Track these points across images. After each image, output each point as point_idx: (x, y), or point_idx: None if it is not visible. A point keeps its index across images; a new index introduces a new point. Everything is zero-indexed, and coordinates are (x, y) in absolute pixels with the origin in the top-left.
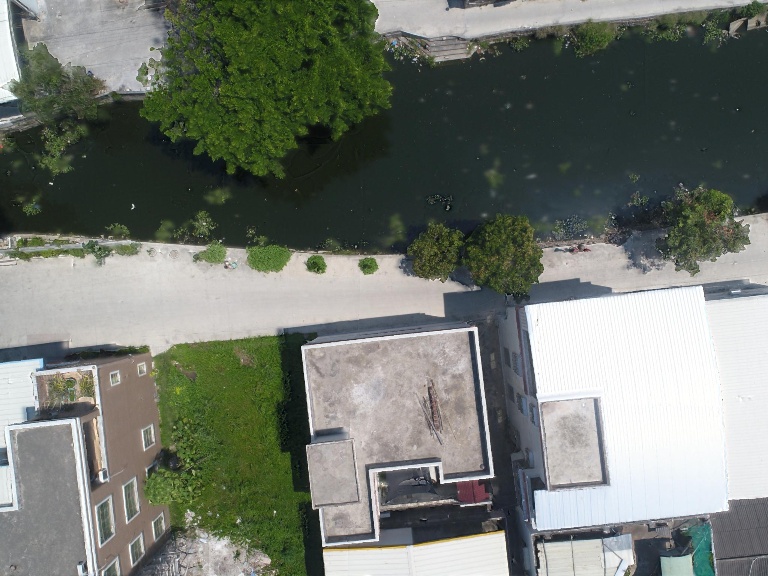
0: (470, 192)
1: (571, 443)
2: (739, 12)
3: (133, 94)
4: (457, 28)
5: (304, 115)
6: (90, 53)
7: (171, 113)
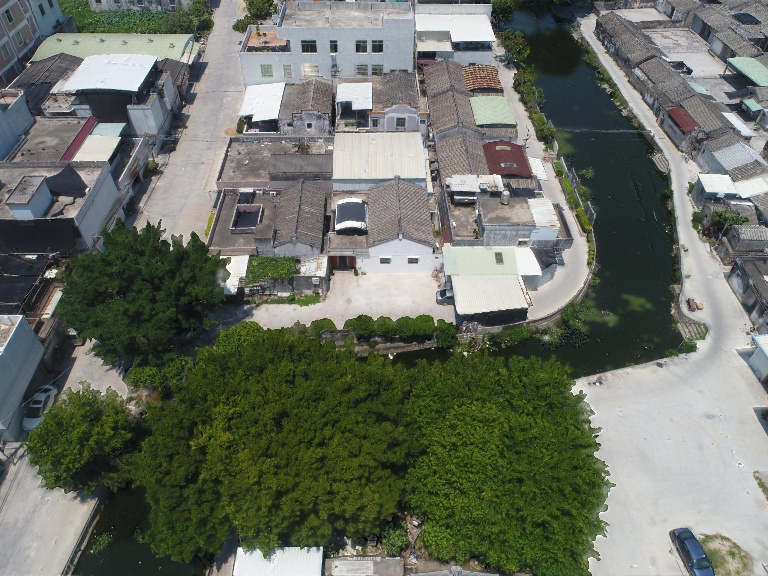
0: None
1: None
2: None
3: None
4: None
5: None
6: None
7: None
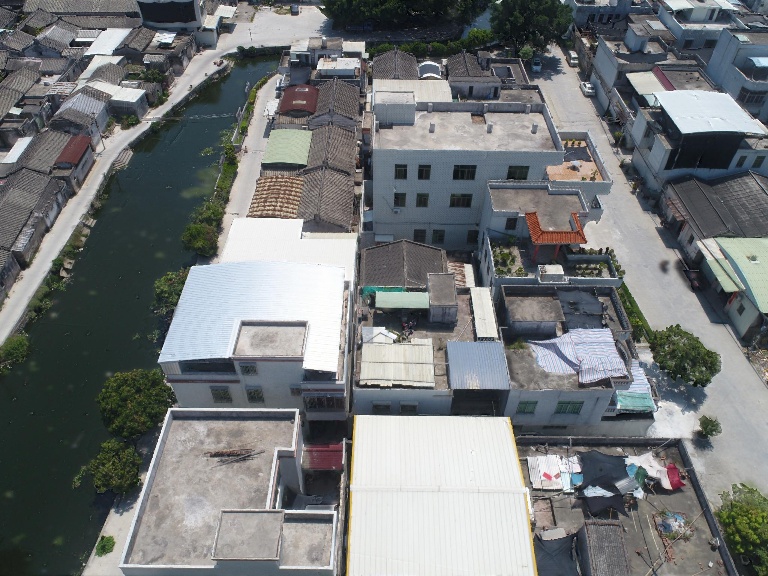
0: (86, 451)
1: (272, 342)
2: (55, 270)
3: None
4: None
5: None
6: None
7: None
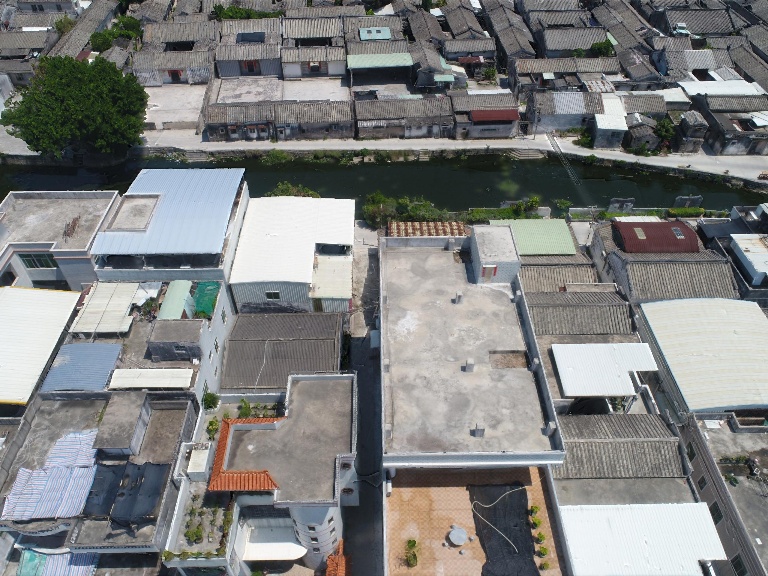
0: None
1: (134, 215)
2: (357, 153)
3: (13, 156)
4: (203, 148)
5: (77, 119)
6: (3, 143)
7: (12, 118)
